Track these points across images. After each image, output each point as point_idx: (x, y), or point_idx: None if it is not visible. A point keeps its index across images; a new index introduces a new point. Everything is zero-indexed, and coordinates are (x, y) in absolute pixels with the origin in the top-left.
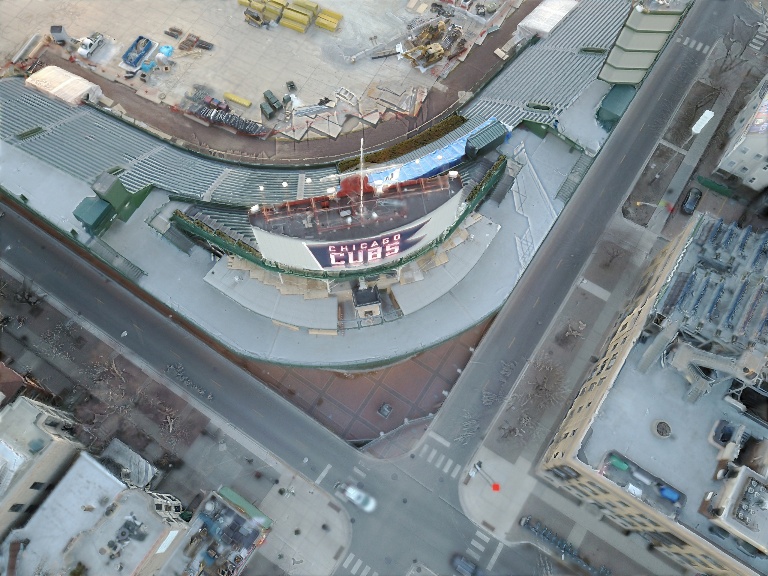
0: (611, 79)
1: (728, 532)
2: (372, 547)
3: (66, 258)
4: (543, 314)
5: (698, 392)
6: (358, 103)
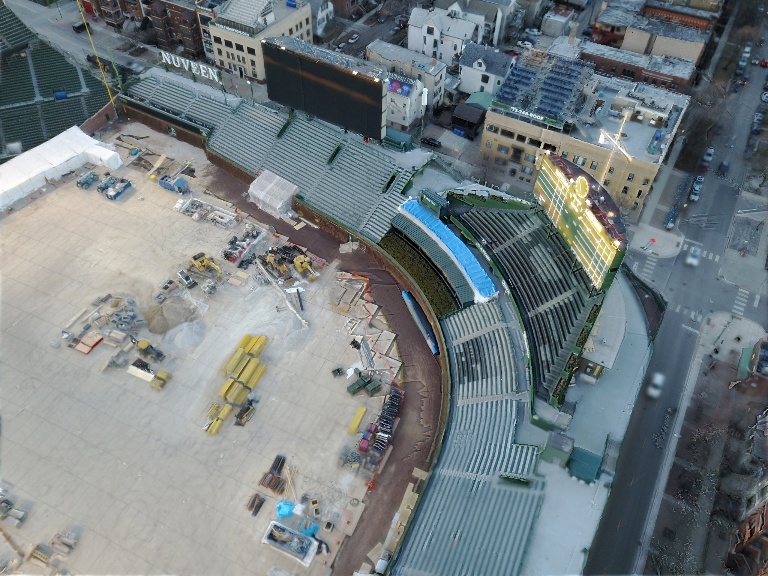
0: (385, 134)
1: (665, 121)
2: (723, 300)
3: (583, 575)
4: None
5: (598, 121)
6: None
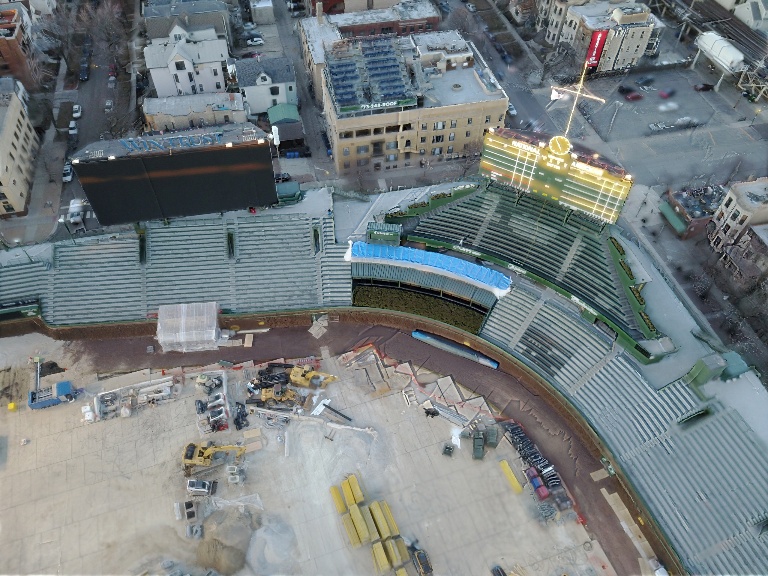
0: None
1: None
2: None
3: None
4: None
5: None
6: None
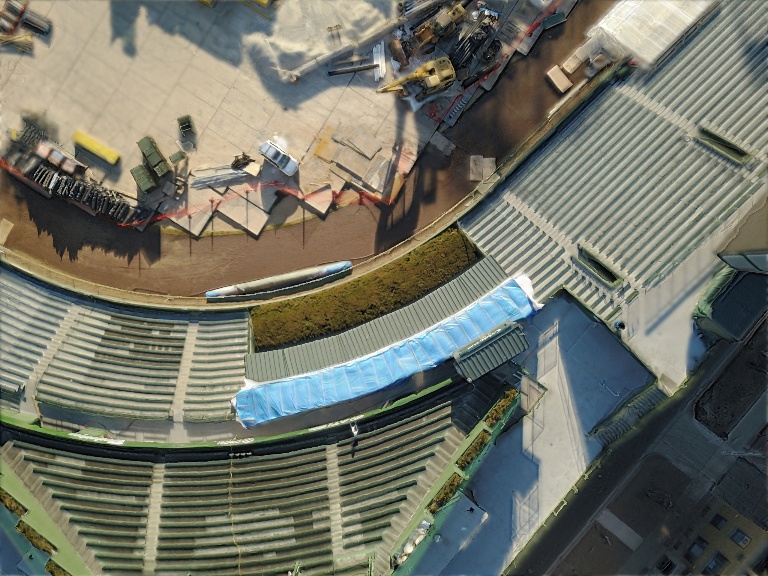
0: (744, 270)
1: None
2: None
3: None
4: (538, 560)
5: None
6: (298, 169)
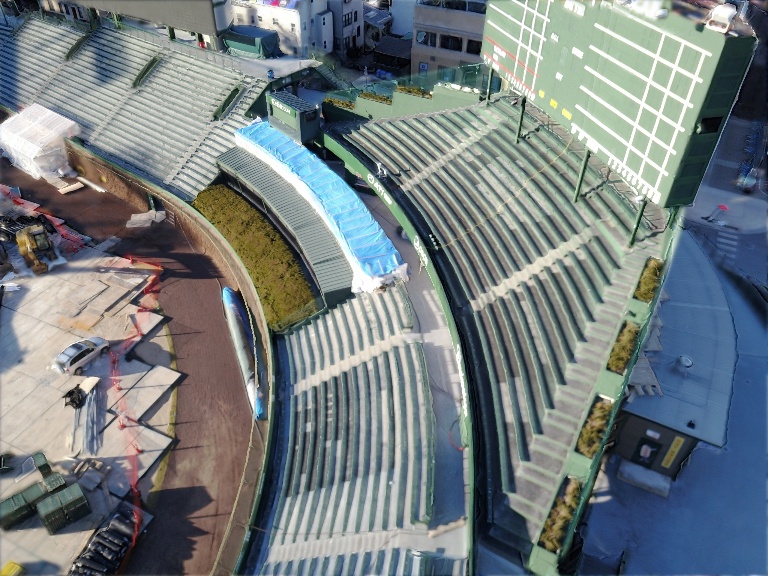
0: (227, 23)
1: None
2: None
3: None
4: None
5: None
6: None
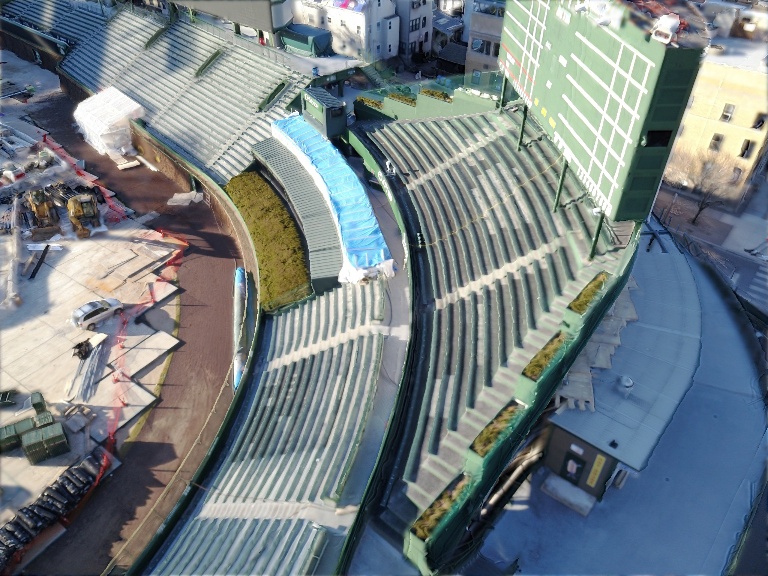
0: (284, 21)
1: None
2: None
3: None
4: None
5: None
6: None
